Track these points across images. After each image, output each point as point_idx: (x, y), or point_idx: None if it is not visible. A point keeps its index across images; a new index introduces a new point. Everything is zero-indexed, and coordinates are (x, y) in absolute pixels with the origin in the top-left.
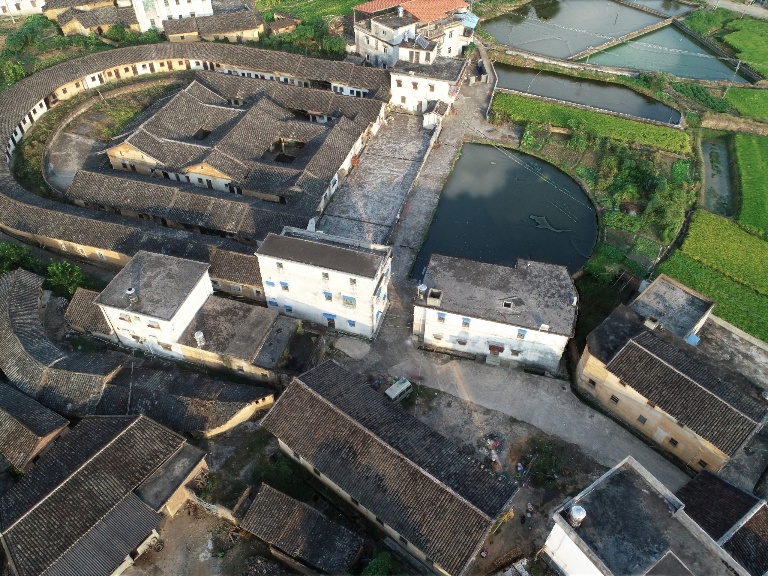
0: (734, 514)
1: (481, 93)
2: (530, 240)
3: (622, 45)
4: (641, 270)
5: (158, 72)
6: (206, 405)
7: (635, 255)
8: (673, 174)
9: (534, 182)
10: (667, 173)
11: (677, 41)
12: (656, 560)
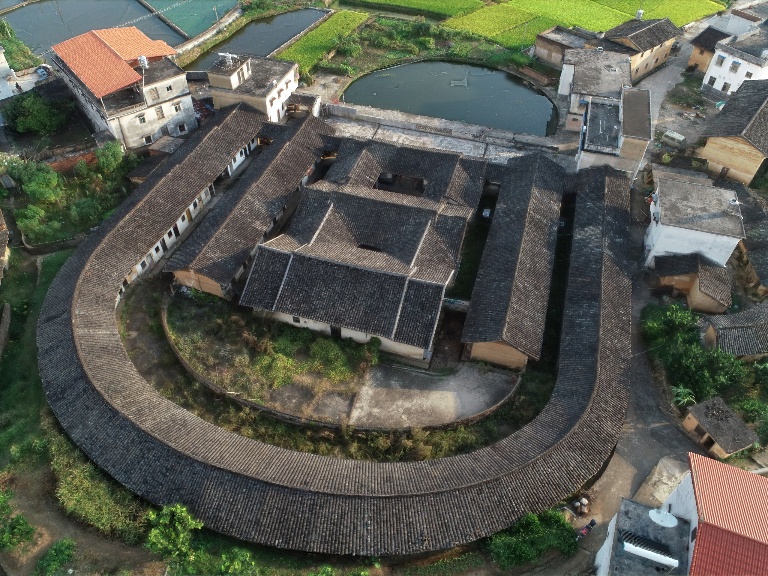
0: (720, 34)
1: None
2: (484, 88)
3: None
4: (513, 52)
5: None
6: (760, 201)
7: None
8: None
9: (405, 79)
10: None
11: None
12: (763, 48)
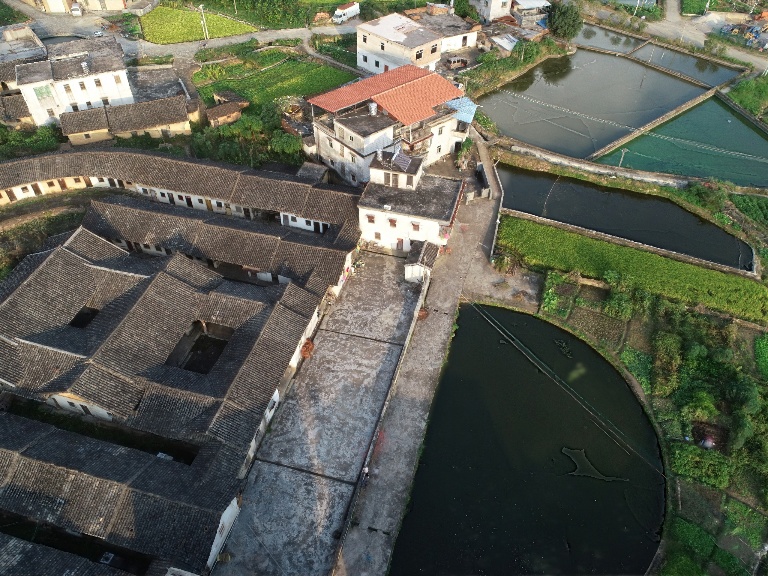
0: None
1: (482, 216)
2: (566, 504)
3: (657, 130)
4: None
5: (46, 194)
6: None
7: (732, 548)
8: (758, 362)
9: (563, 379)
10: (750, 360)
11: (725, 123)
12: None
